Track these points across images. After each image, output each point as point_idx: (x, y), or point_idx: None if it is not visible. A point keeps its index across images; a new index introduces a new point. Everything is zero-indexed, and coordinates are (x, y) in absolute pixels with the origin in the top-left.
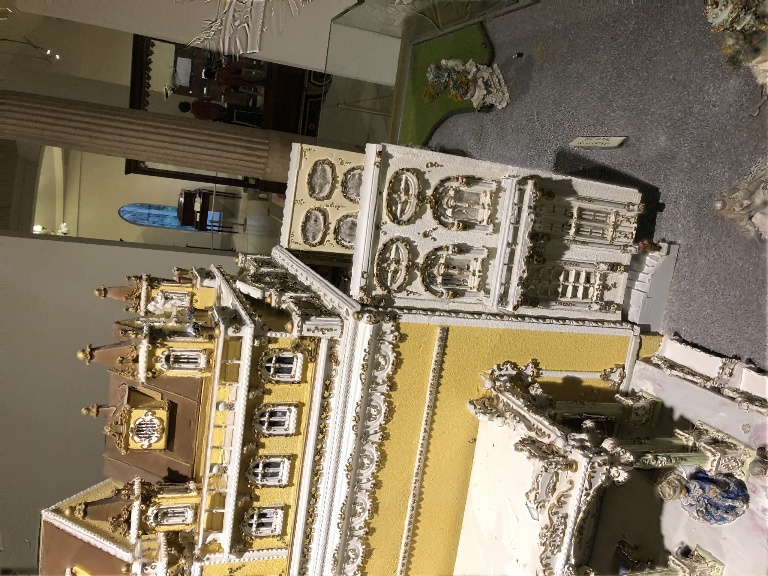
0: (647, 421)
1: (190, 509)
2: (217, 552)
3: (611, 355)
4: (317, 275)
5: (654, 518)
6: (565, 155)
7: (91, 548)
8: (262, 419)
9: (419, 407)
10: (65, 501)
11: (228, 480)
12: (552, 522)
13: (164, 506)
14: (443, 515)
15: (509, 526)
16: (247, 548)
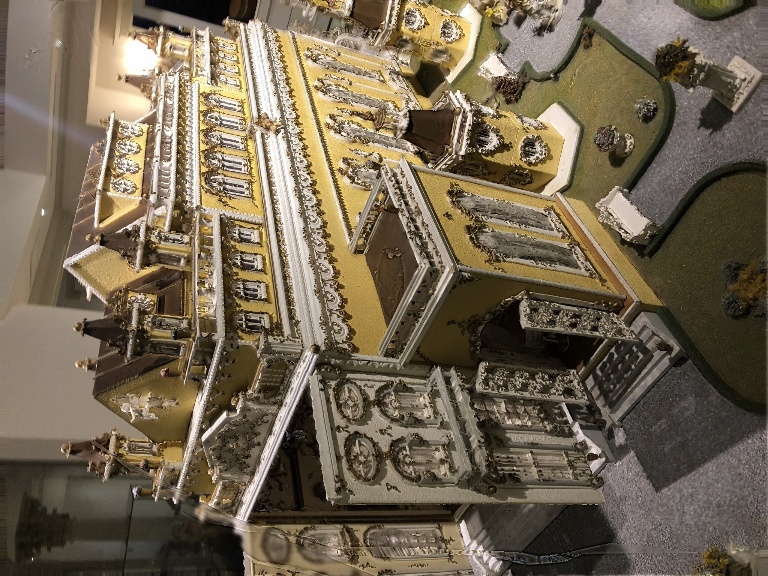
0: None
1: None
2: None
3: None
4: (264, 476)
5: None
6: (619, 570)
7: None
8: None
9: None
10: (81, 257)
11: None
12: None
13: None
14: None
15: None
16: None
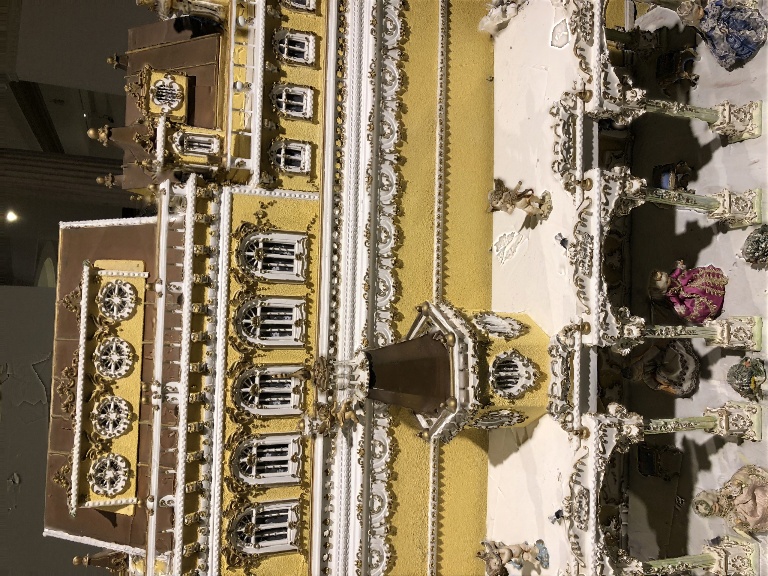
0: (656, 48)
1: (216, 138)
2: (247, 184)
3: (610, 17)
4: None
5: (684, 131)
6: None
7: (113, 232)
8: (281, 44)
9: (433, 33)
10: None
11: (253, 99)
12: (579, 10)
13: (190, 132)
14: (473, 157)
15: (539, 87)
16: (277, 185)
